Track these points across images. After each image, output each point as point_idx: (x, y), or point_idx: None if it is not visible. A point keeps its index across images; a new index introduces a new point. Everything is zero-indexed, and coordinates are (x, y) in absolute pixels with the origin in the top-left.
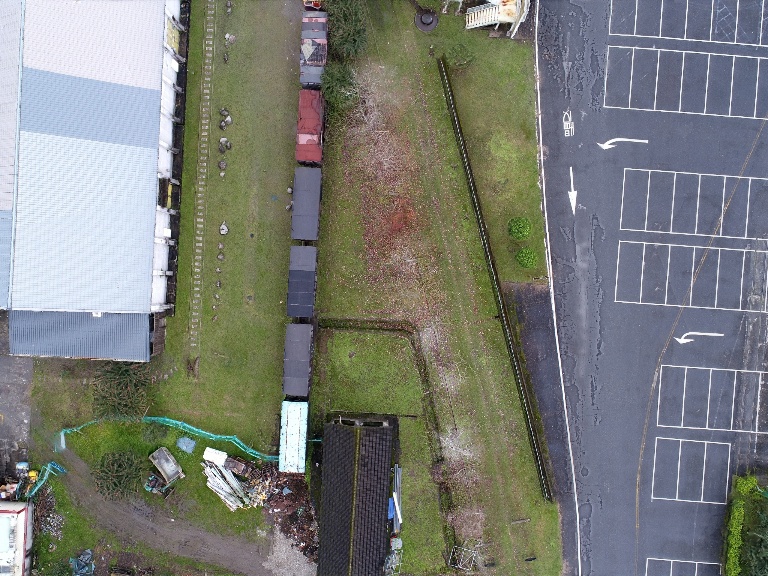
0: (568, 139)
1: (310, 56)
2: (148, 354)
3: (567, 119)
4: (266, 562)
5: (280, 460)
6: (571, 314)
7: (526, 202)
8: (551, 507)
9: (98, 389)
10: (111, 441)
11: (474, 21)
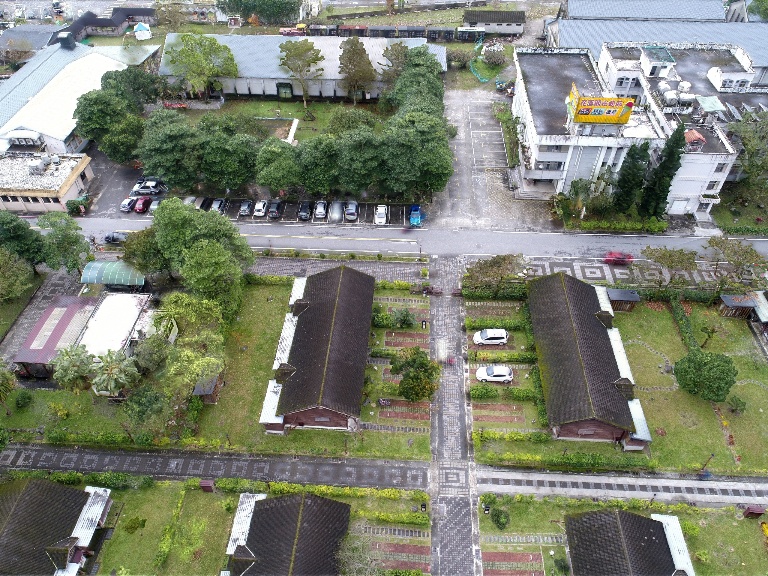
0: (359, 3)
1: (326, 26)
2: (442, 46)
3: (352, 3)
4: (525, 45)
5: (480, 31)
6: (420, 2)
7: (381, 8)
8: (488, 4)
9: (458, 55)
10: (483, 71)
11: (315, 14)
